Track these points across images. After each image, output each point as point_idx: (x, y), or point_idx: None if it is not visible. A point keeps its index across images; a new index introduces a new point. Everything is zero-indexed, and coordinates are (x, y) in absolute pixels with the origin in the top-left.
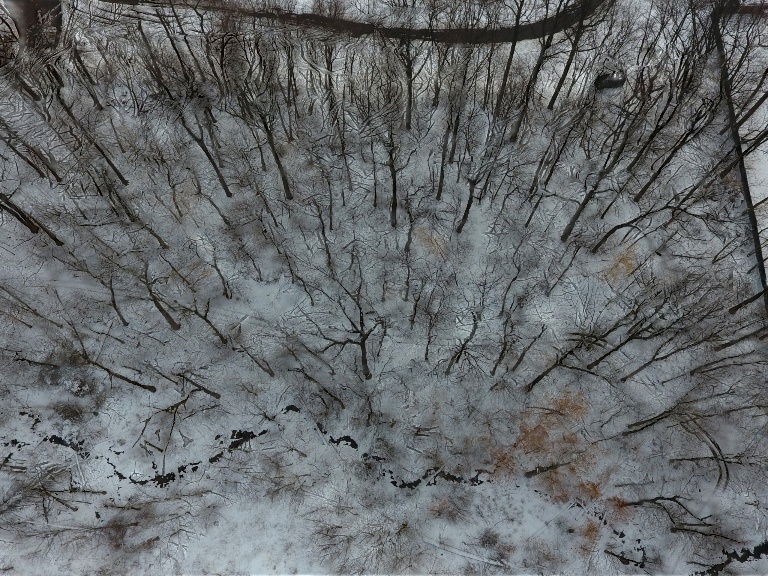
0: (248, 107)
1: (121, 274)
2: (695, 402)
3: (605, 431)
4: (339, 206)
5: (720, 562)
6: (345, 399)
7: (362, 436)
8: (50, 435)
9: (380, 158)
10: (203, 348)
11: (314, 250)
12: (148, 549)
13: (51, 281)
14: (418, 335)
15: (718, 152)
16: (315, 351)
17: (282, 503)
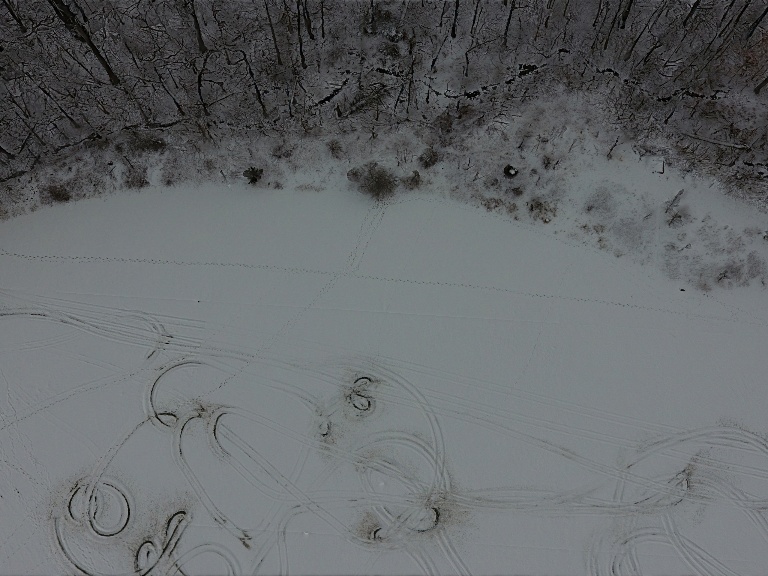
0: None
1: None
2: None
3: None
4: None
5: None
6: None
7: (623, 66)
8: (376, 67)
9: None
10: (488, 8)
11: None
12: (478, 125)
13: None
14: (656, 1)
15: None
16: None
17: (576, 97)
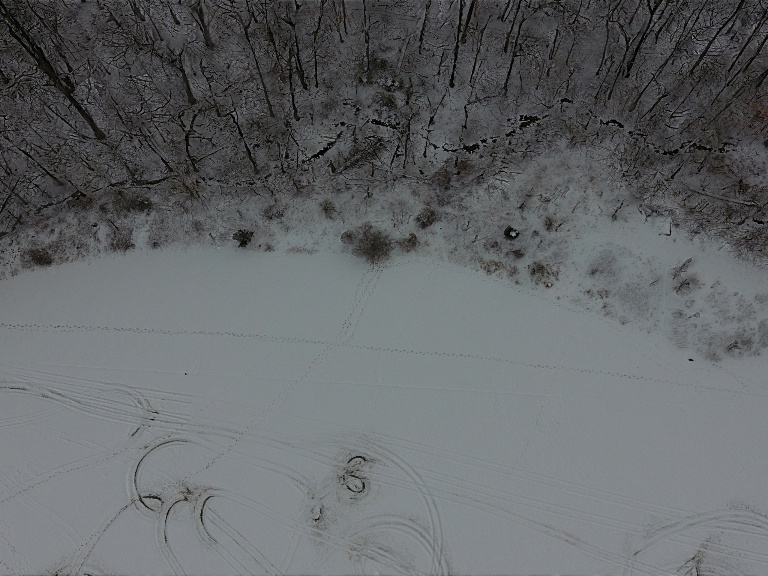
0: None
1: (411, 4)
2: None
3: None
4: None
5: None
6: None
7: (628, 117)
8: (371, 119)
9: None
10: (488, 56)
11: None
12: (478, 183)
13: (353, 10)
14: (662, 48)
15: None
16: None
17: (579, 153)
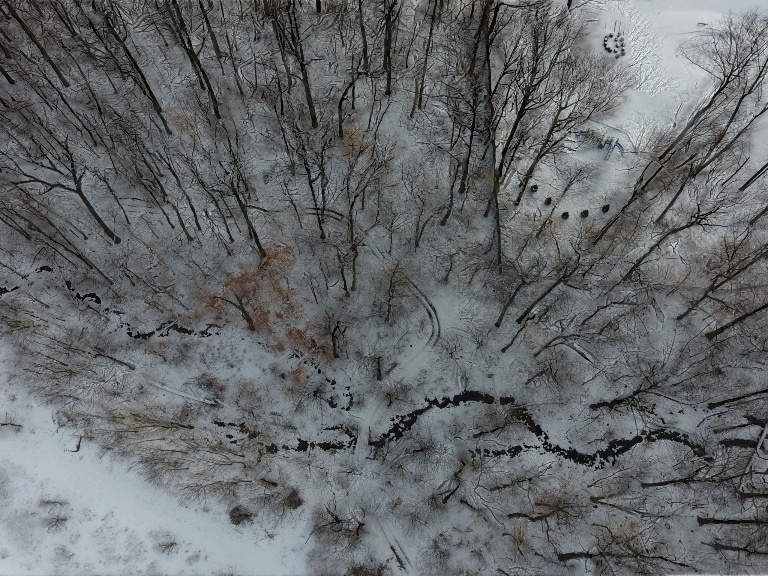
0: (35, 4)
1: None
2: (418, 270)
3: (331, 293)
4: (111, 93)
5: (421, 408)
6: (91, 259)
7: (105, 292)
8: None
9: (153, 51)
10: None
11: (83, 131)
12: None
13: None
14: (170, 207)
15: (460, 49)
16: (40, 200)
17: (14, 343)
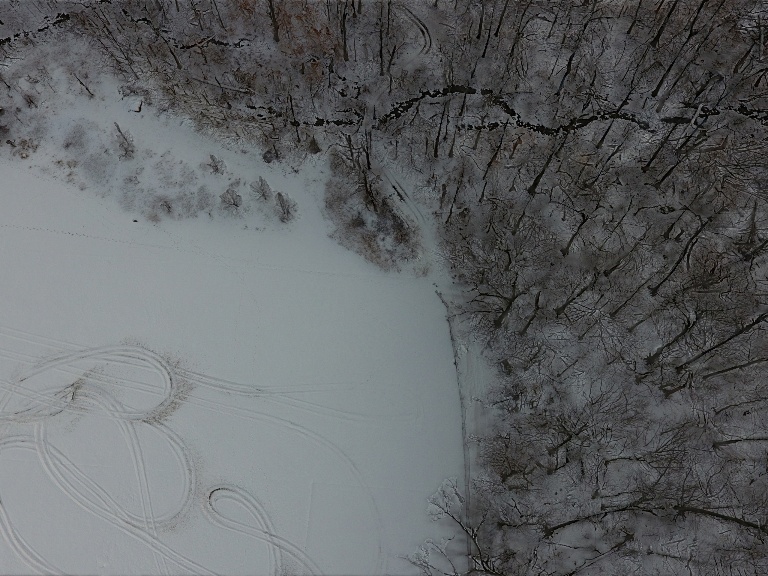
0: None
1: None
2: None
3: None
4: None
5: (416, 97)
6: None
7: (155, 15)
8: None
9: None
10: None
11: None
12: None
13: None
14: None
15: None
16: None
17: (84, 42)
